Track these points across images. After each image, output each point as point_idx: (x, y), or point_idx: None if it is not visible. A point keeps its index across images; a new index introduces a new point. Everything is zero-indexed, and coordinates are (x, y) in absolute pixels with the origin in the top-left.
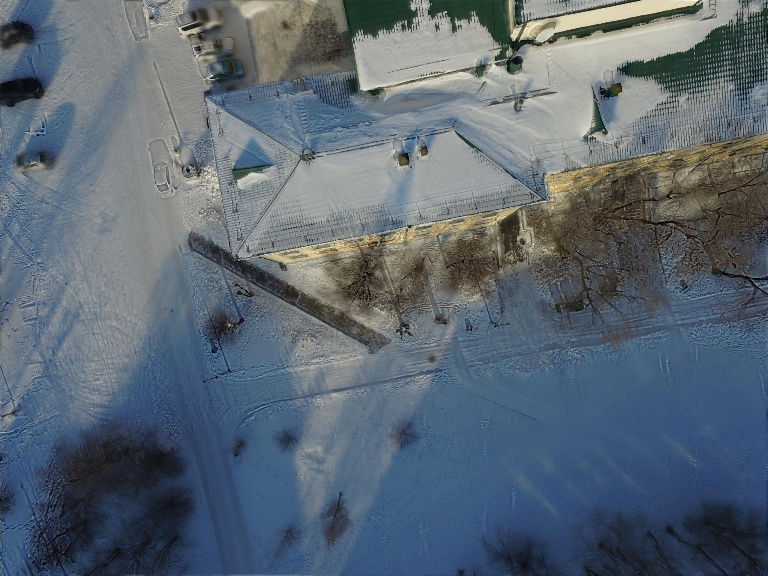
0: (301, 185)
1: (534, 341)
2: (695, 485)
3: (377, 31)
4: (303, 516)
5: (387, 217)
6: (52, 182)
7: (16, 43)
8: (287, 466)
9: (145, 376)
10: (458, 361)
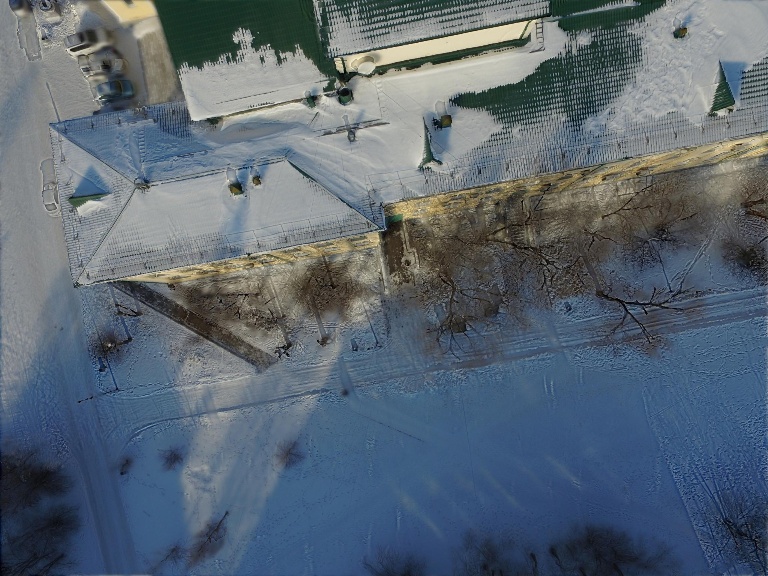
0: (138, 213)
1: (420, 362)
2: (579, 507)
3: (202, 63)
4: (189, 535)
5: (225, 245)
6: None
7: None
8: (174, 485)
9: (34, 394)
10: (344, 381)
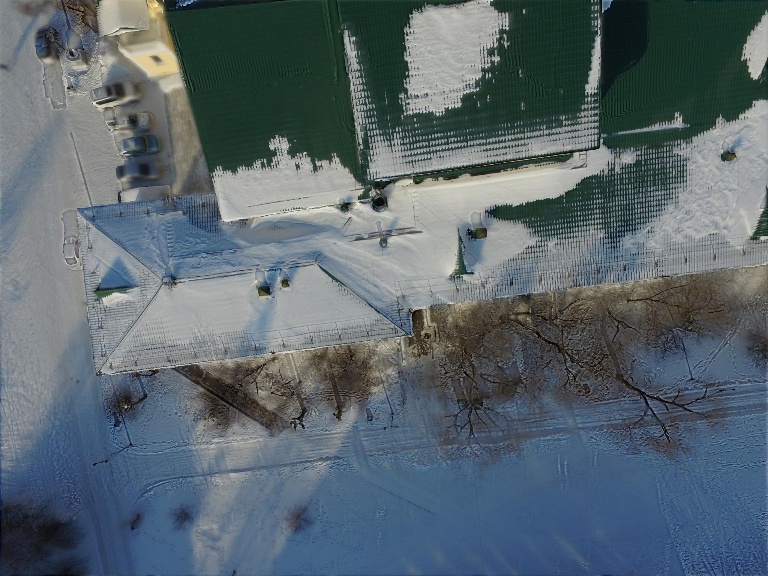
0: (163, 308)
1: (434, 435)
2: None
3: (236, 167)
4: None
5: (250, 343)
6: None
7: None
8: (183, 542)
9: (49, 444)
10: (357, 450)
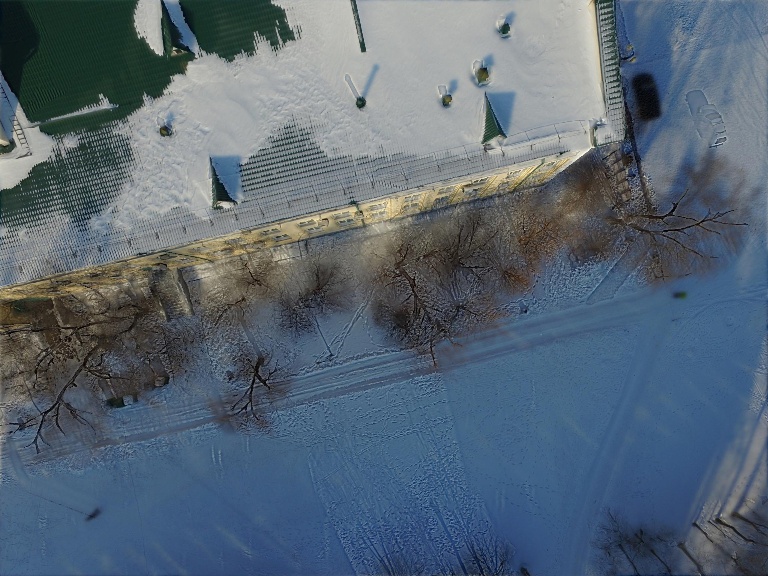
0: None
1: (88, 437)
2: None
3: None
4: None
5: None
6: None
7: None
8: None
9: None
10: (14, 461)
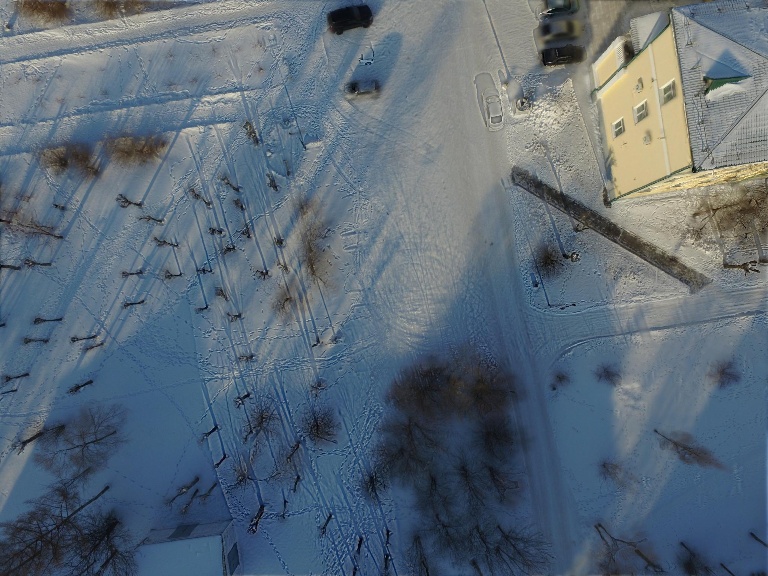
0: None
1: None
2: None
3: None
4: (617, 452)
5: None
6: (376, 111)
7: None
8: (604, 402)
9: (463, 308)
10: None
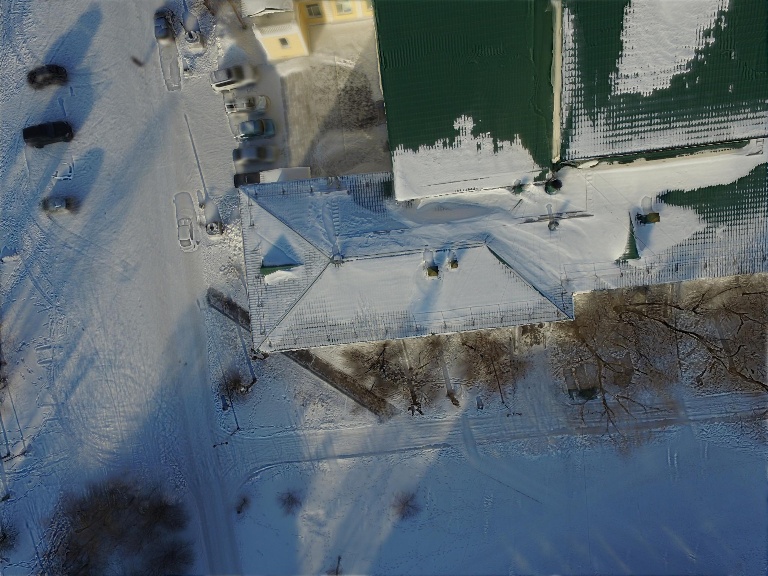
0: (328, 287)
1: (544, 424)
2: None
3: (417, 146)
4: None
5: (411, 324)
6: (76, 227)
7: (49, 85)
8: (289, 527)
9: (155, 426)
10: (466, 438)
